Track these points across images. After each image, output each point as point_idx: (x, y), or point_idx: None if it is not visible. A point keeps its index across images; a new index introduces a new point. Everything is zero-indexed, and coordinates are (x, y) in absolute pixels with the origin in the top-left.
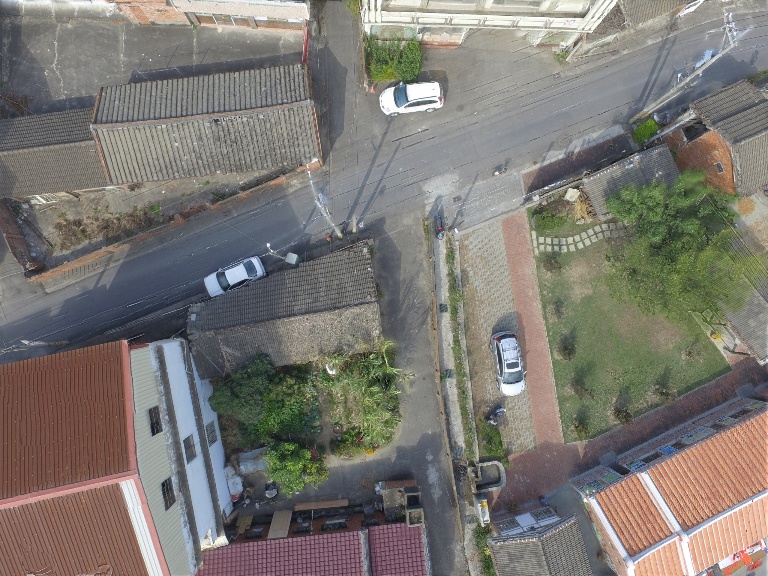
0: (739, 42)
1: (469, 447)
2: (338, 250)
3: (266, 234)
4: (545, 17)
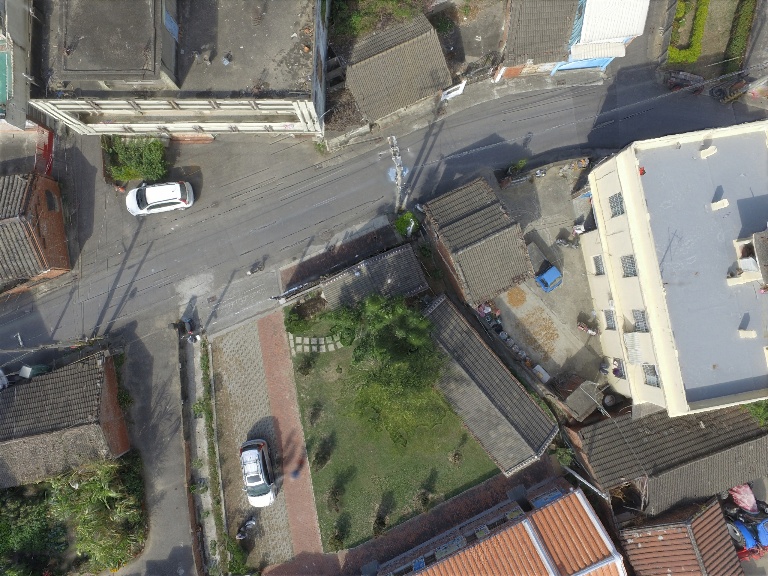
0: (511, 124)
1: (224, 559)
2: (74, 362)
3: (12, 342)
4: (261, 123)
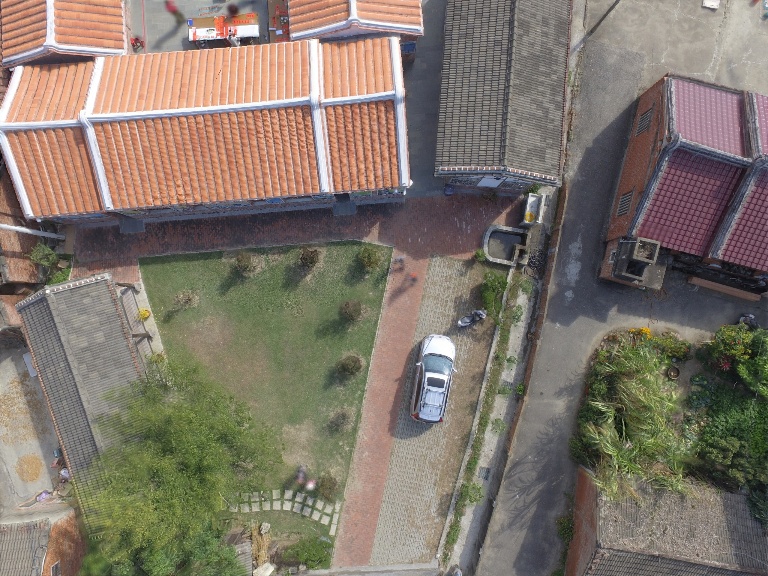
0: None
1: (515, 288)
2: None
3: None
4: None
